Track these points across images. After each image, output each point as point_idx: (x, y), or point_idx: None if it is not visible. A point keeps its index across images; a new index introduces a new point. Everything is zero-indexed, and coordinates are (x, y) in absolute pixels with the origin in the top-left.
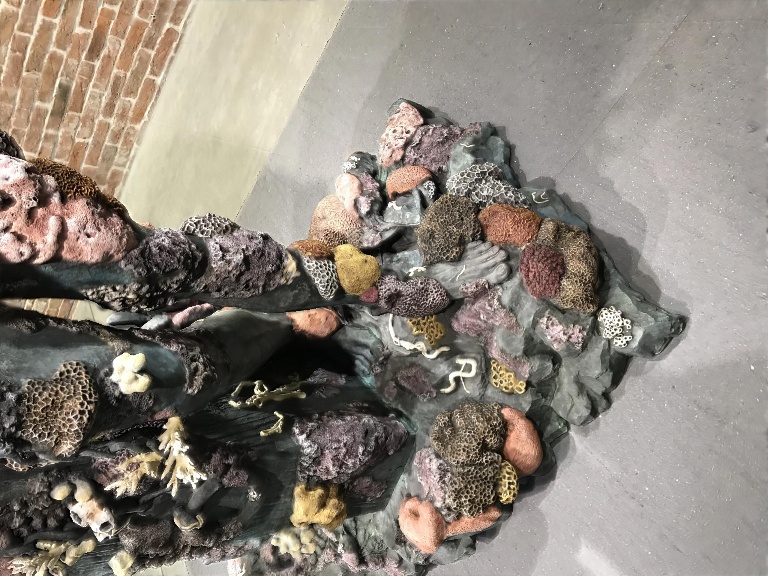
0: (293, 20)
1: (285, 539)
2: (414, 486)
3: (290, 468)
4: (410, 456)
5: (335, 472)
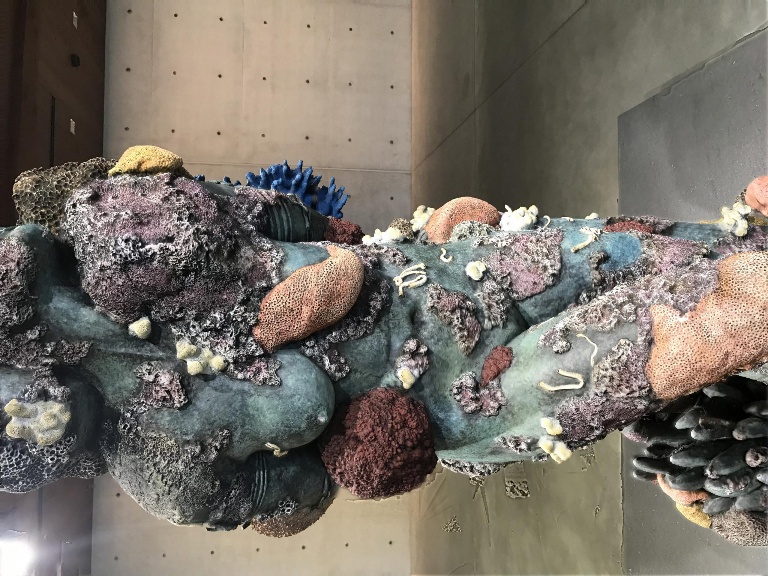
0: None
1: (725, 219)
2: None
3: None
4: None
5: None
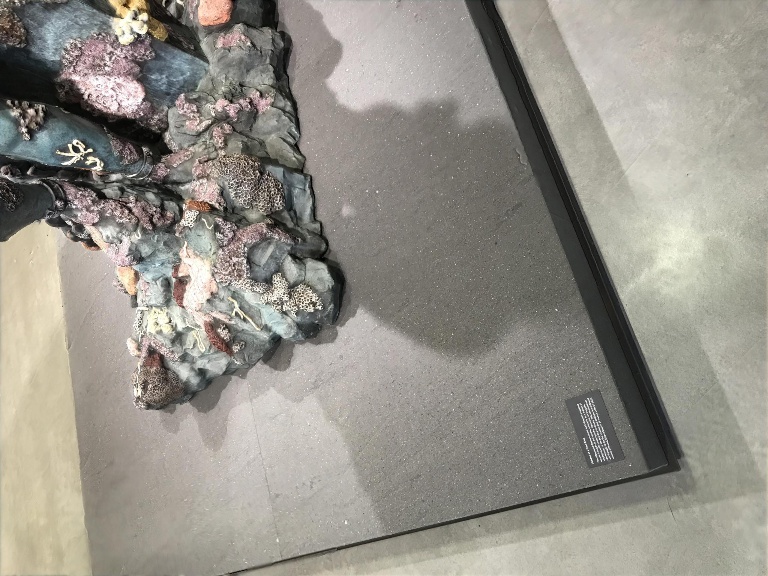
0: (35, 240)
1: (123, 21)
2: None
3: None
4: (194, 34)
5: None
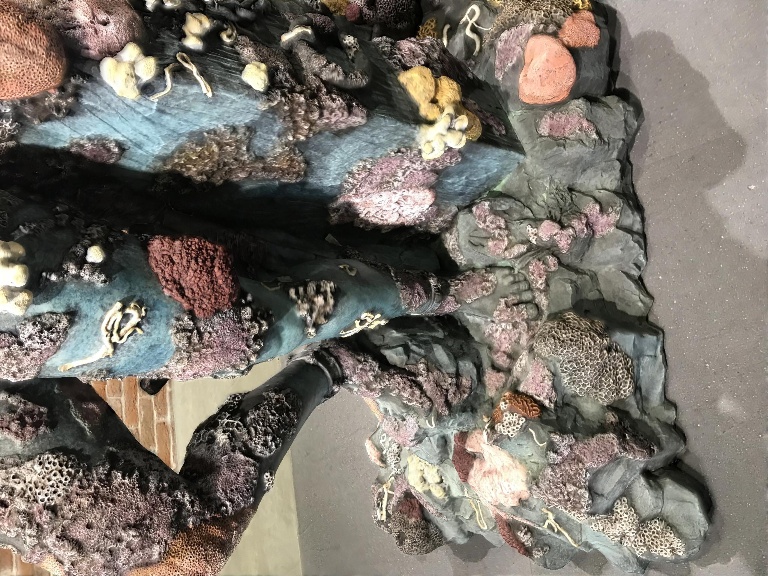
0: None
1: (432, 131)
2: (514, 79)
3: (376, 56)
4: (498, 98)
5: (420, 50)
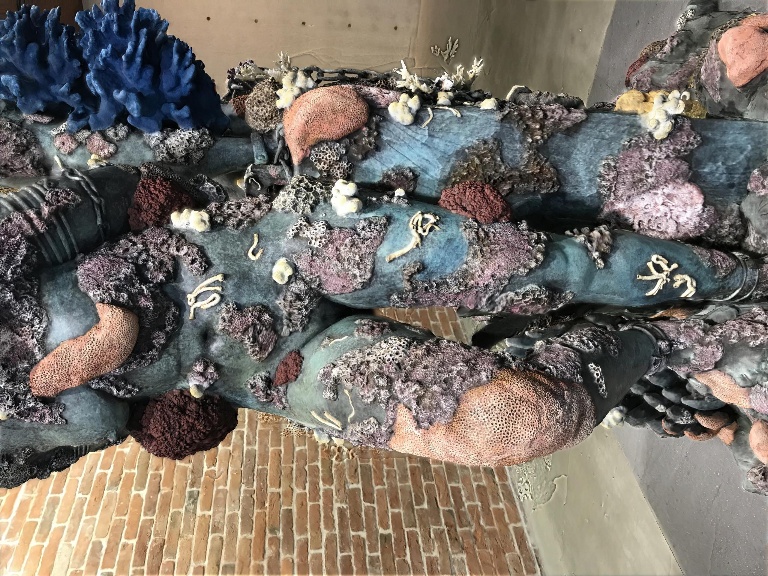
0: (601, 488)
1: (652, 112)
2: (728, 85)
3: None
4: (729, 115)
5: None
